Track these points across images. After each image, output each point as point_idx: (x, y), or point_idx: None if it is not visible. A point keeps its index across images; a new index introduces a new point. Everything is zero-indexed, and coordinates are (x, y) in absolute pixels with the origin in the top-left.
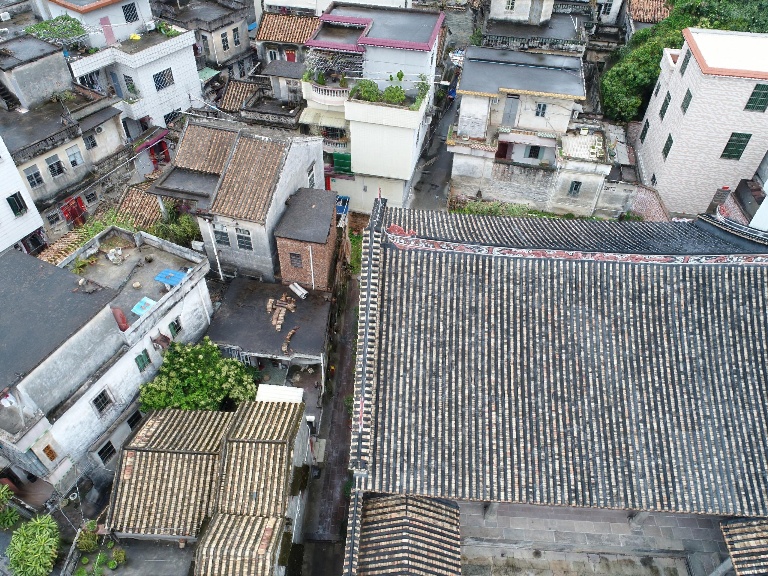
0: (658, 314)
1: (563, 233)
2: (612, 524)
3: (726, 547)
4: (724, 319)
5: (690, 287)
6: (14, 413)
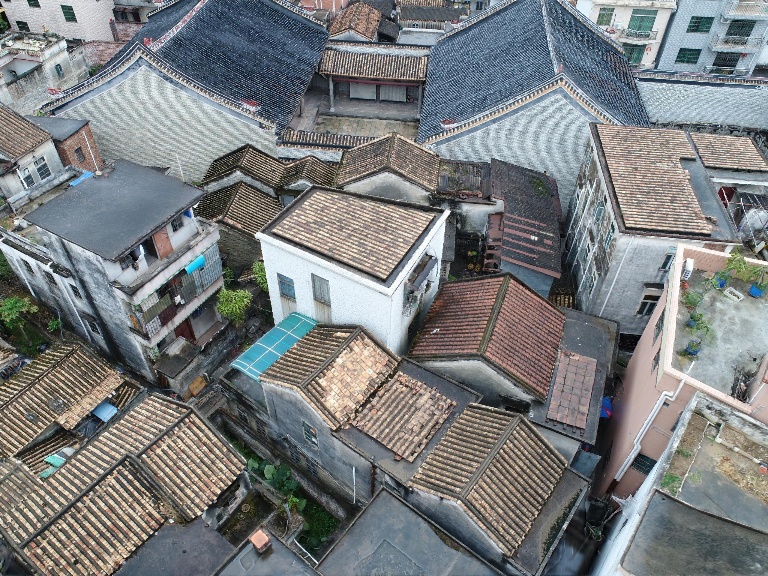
0: None
1: None
2: (301, 122)
3: (328, 74)
4: (241, 8)
5: (222, 4)
6: (183, 246)
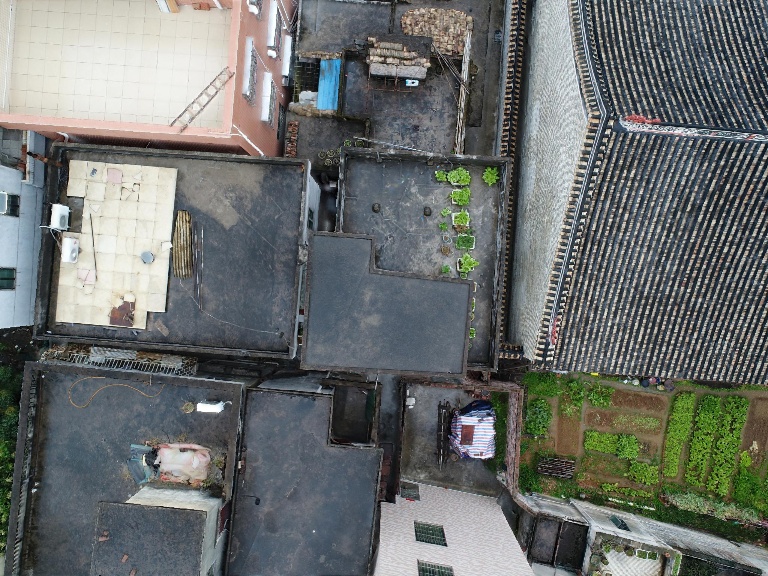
0: (759, 98)
1: (762, 320)
2: None
3: None
4: None
5: None
6: None
